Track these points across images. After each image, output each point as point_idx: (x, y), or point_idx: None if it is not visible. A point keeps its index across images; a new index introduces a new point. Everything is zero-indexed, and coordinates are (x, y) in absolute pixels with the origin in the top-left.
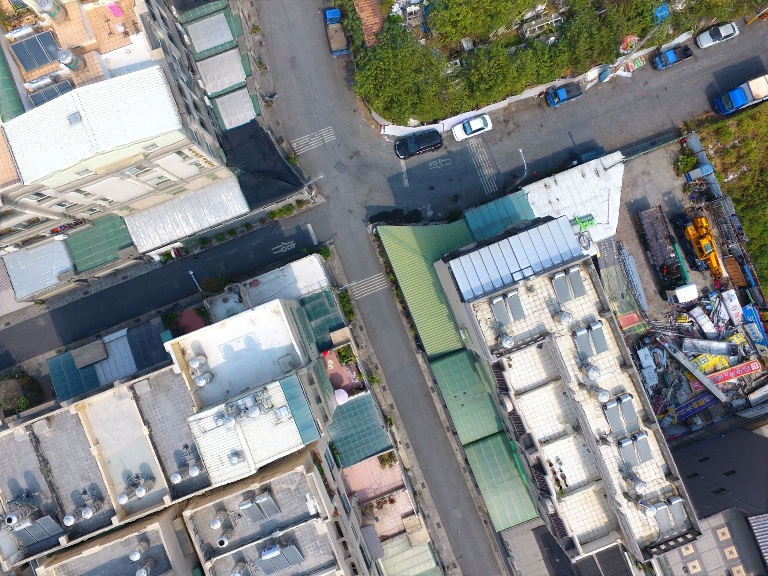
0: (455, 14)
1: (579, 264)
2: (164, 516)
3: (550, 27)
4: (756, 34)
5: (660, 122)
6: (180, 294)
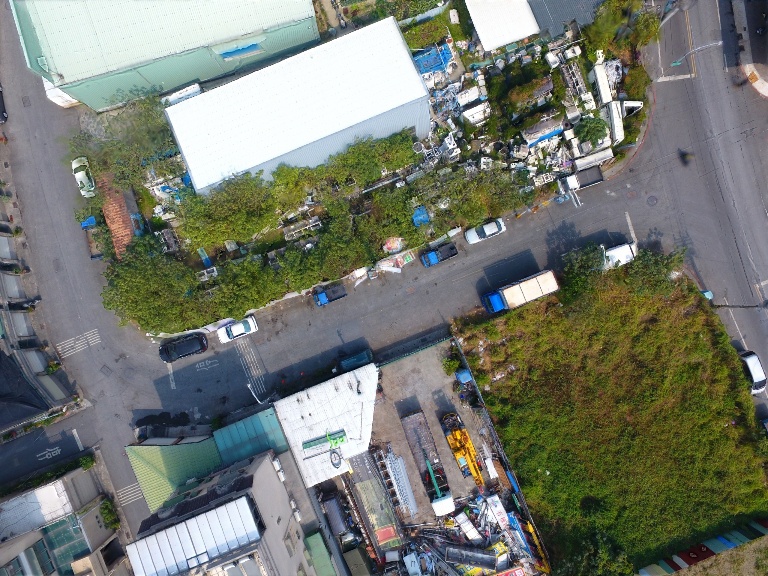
0: (193, 237)
1: (249, 555)
2: None
3: (307, 232)
4: (527, 227)
5: (430, 318)
6: None
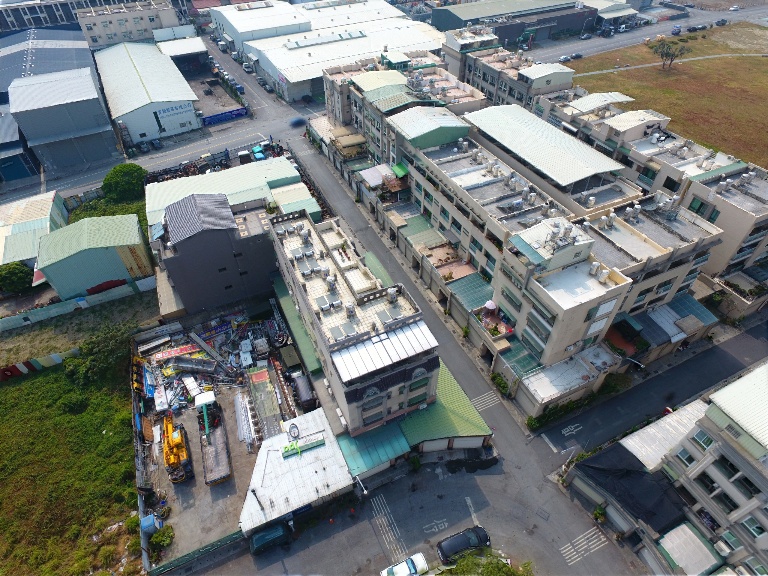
0: None
1: None
2: None
3: None
4: None
5: None
6: (646, 386)
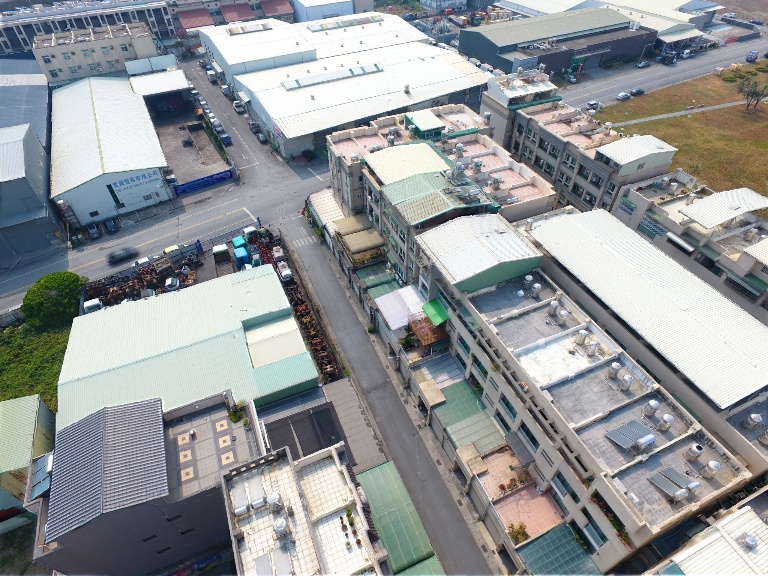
0: None
1: None
2: (764, 470)
3: None
4: None
5: None
6: None
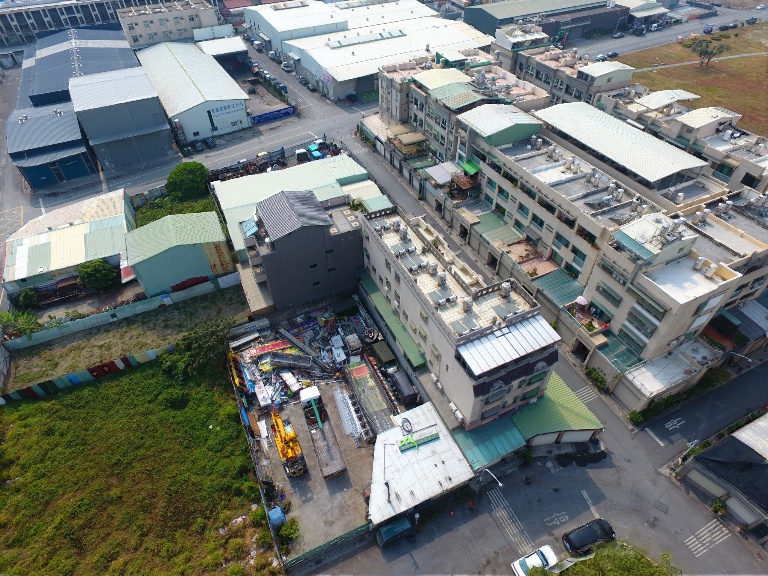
0: None
1: None
2: None
3: None
4: None
5: None
6: (741, 381)
